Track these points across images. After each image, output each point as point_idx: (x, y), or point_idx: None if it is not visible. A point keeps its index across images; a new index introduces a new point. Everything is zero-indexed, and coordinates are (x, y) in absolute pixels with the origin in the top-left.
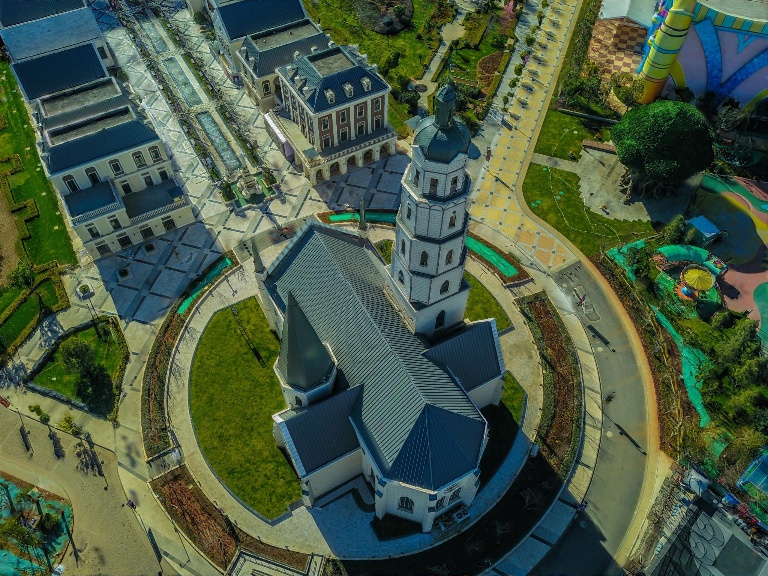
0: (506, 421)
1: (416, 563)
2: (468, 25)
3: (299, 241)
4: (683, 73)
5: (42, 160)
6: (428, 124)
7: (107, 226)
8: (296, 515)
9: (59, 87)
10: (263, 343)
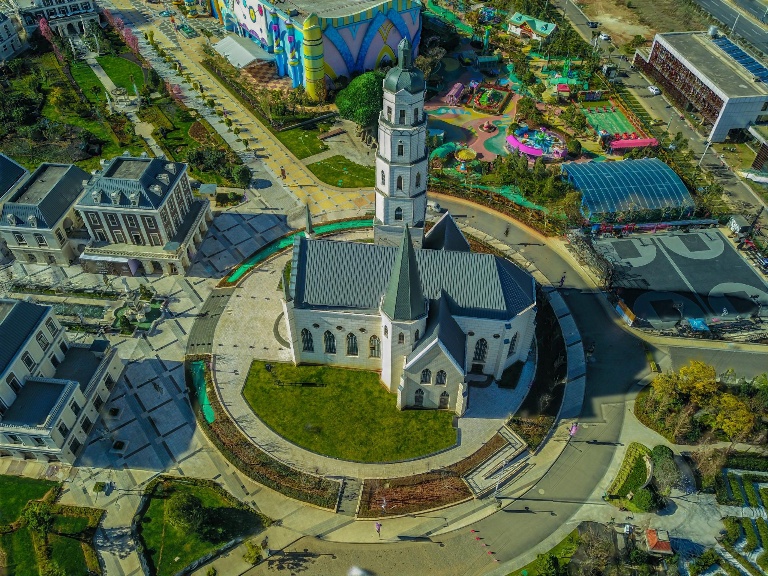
0: None
1: (542, 378)
2: (148, 119)
3: (298, 257)
4: (331, 68)
5: None
6: (399, 73)
7: (71, 415)
8: (462, 427)
9: None
10: (303, 376)
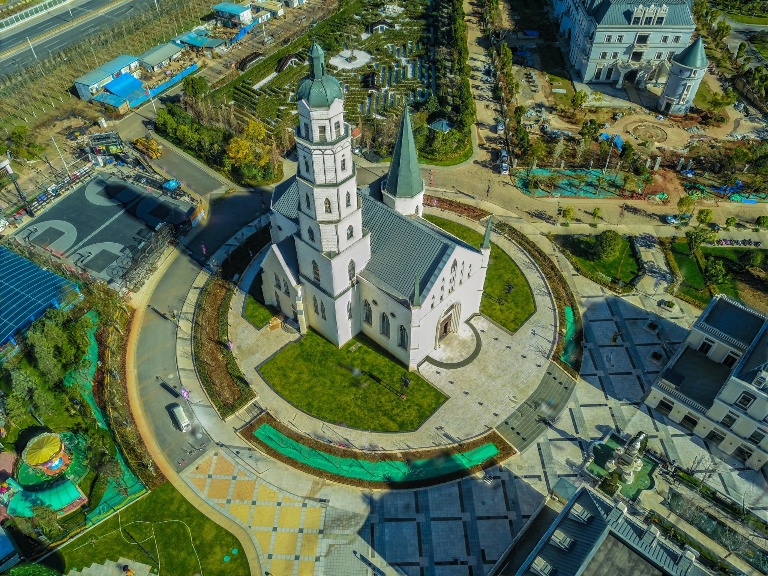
0: (258, 293)
1: None
2: None
3: None
4: None
5: None
6: None
7: None
8: None
9: None
10: None
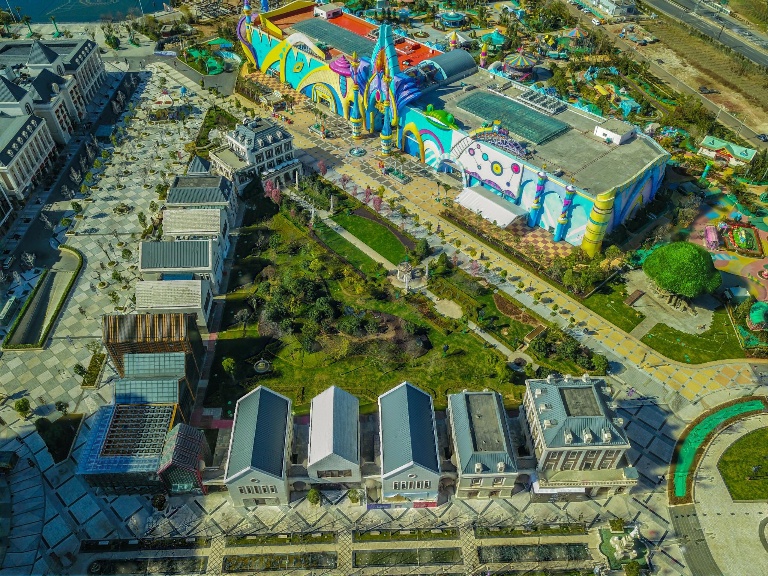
0: None
1: None
2: (446, 296)
3: None
4: None
5: None
6: None
7: None
8: None
9: None
10: None
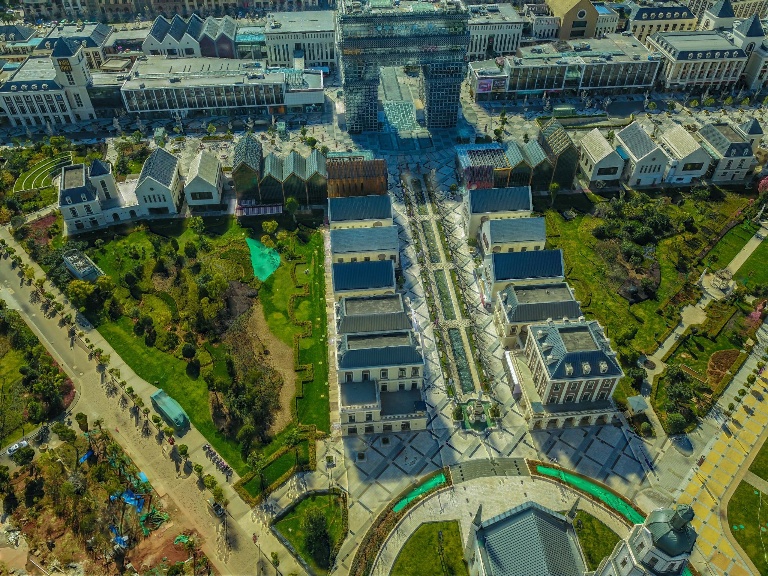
0: None
1: None
2: (710, 313)
3: (516, 514)
4: None
5: (336, 354)
6: (663, 520)
7: (363, 417)
8: None
9: (358, 286)
10: (454, 569)
